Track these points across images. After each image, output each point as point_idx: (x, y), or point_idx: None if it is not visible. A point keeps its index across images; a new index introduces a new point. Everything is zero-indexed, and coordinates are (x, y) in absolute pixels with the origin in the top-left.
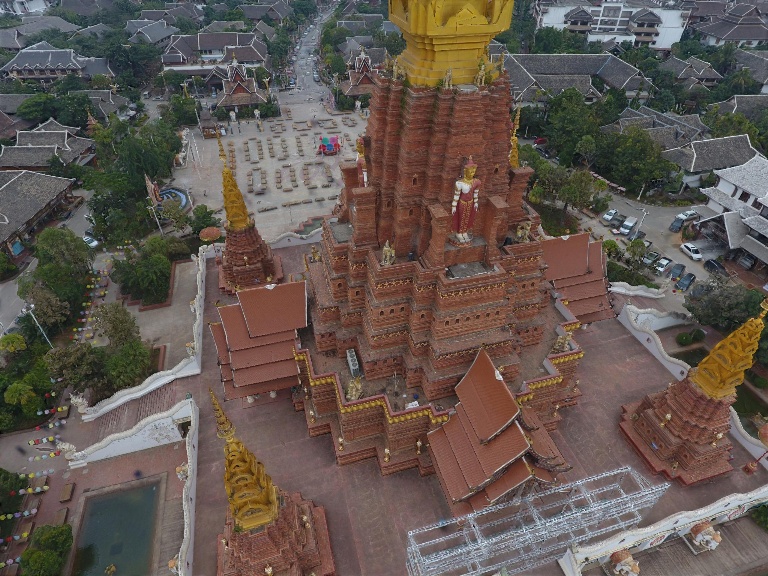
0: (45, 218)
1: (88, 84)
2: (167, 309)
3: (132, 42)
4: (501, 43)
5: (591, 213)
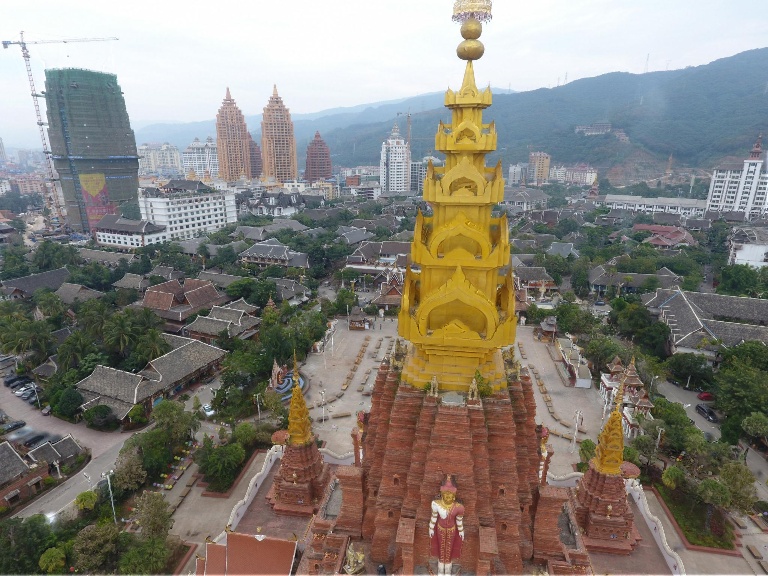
0: (194, 379)
1: (284, 273)
2: (223, 501)
3: (335, 242)
4: (677, 275)
5: (764, 522)
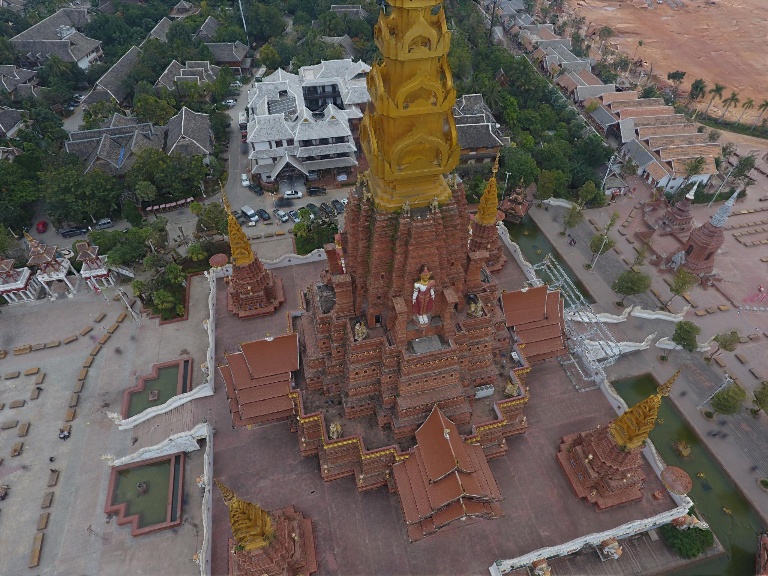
0: None
1: None
2: None
3: None
4: None
5: (216, 230)
